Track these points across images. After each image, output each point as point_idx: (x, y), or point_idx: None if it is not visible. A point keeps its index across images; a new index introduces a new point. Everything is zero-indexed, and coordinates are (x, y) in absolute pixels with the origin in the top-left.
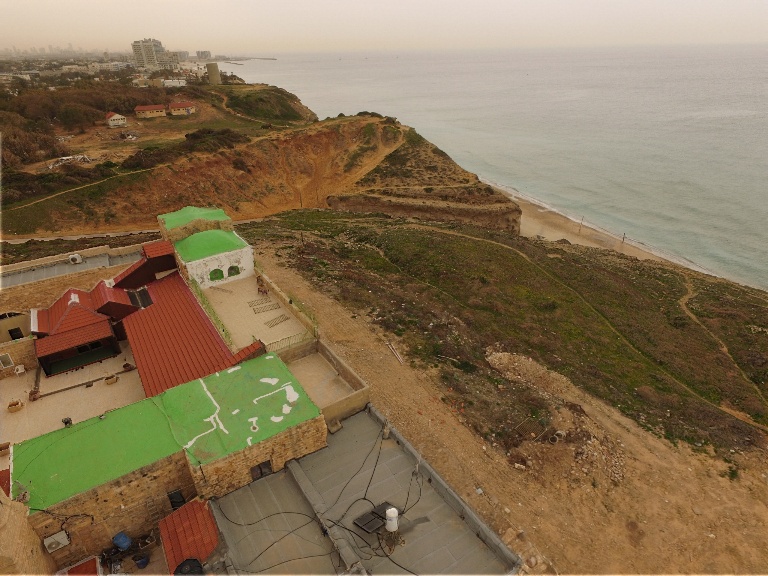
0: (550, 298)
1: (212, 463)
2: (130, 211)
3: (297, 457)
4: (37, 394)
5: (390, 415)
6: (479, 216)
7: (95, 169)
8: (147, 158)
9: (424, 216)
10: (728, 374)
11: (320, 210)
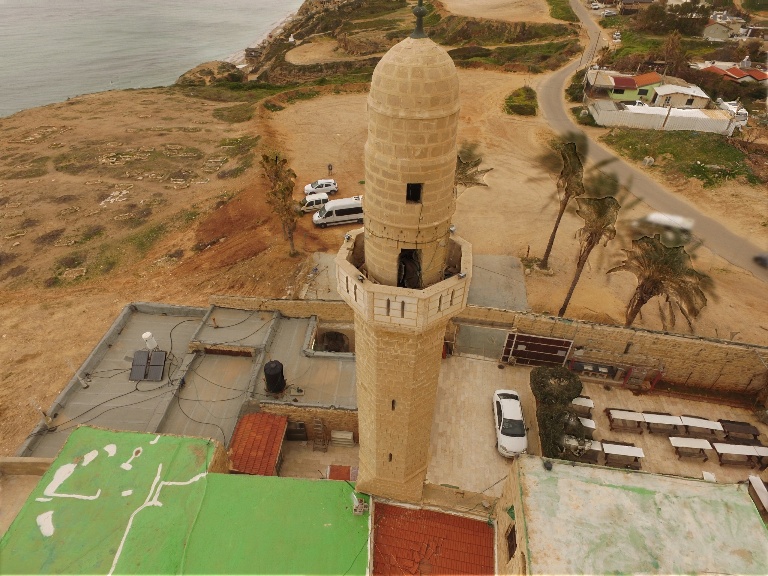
0: None
1: (201, 437)
2: None
3: None
4: None
5: None
6: None
7: None
8: None
9: None
10: None
11: None
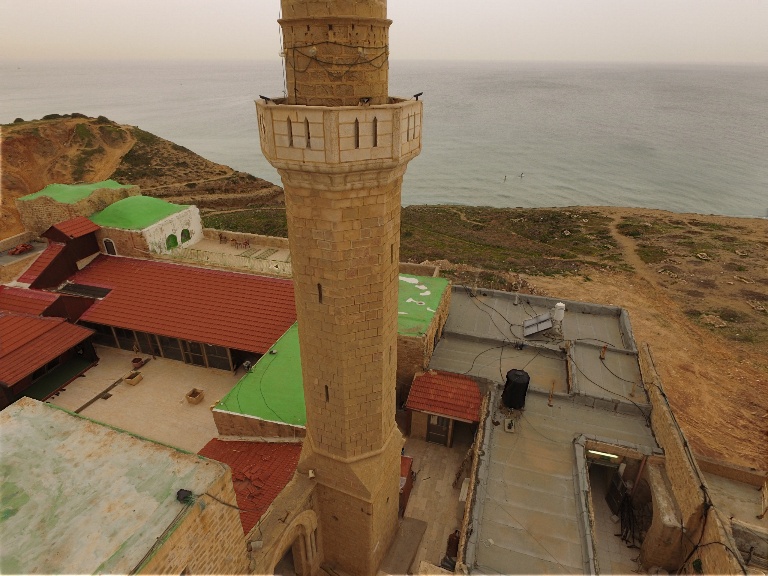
0: None
1: None
2: None
3: None
4: None
5: None
6: None
7: None
8: None
9: None
10: (529, 243)
11: None
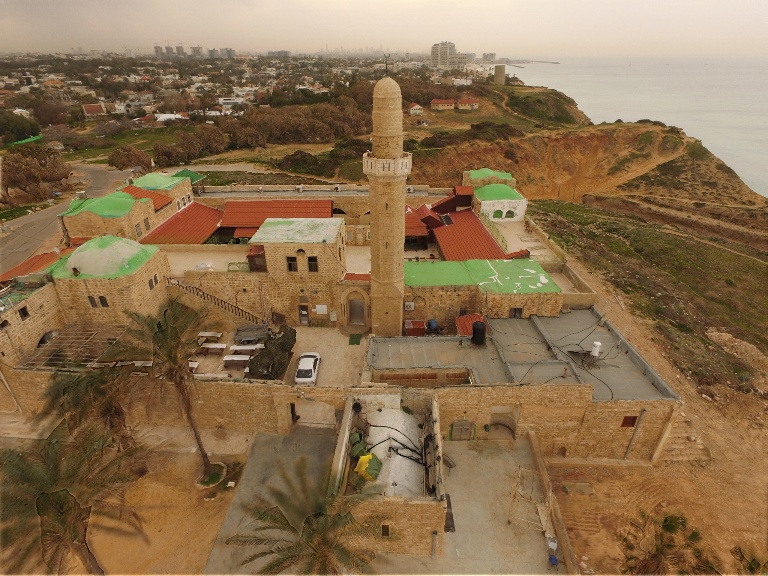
0: None
1: (493, 294)
2: (420, 178)
3: (538, 315)
4: None
5: None
6: (756, 242)
7: (404, 143)
8: (441, 139)
9: (685, 230)
10: None
11: (574, 204)
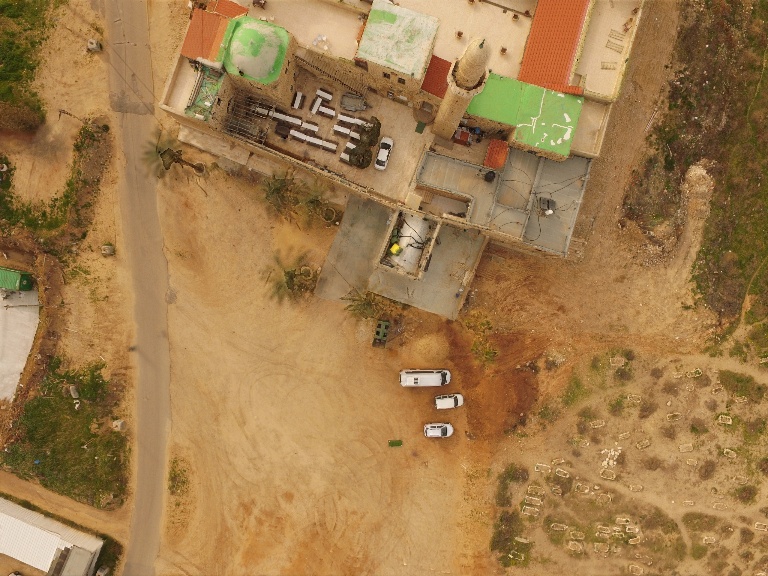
0: None
1: (520, 142)
2: None
3: (547, 158)
4: None
5: (603, 157)
6: None
7: None
8: None
9: None
10: None
11: None
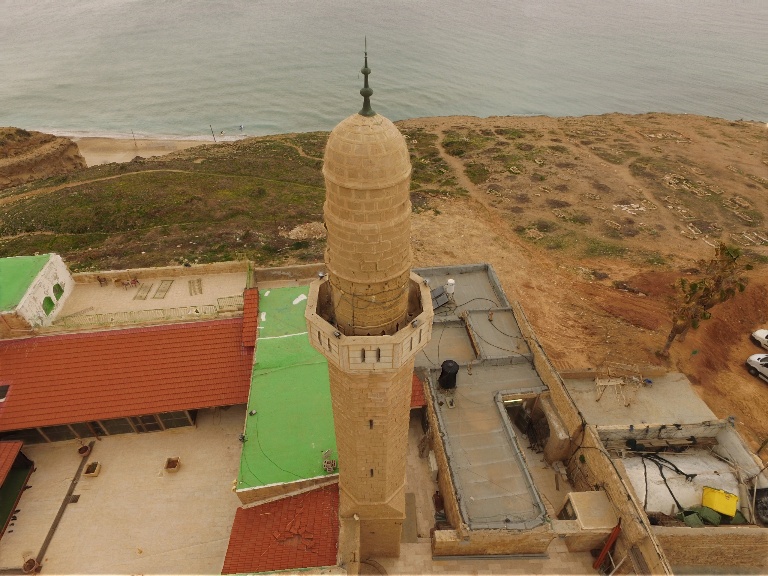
0: (249, 188)
1: None
2: None
3: None
4: (35, 562)
5: None
6: (37, 166)
7: None
8: None
9: None
10: None
11: None
